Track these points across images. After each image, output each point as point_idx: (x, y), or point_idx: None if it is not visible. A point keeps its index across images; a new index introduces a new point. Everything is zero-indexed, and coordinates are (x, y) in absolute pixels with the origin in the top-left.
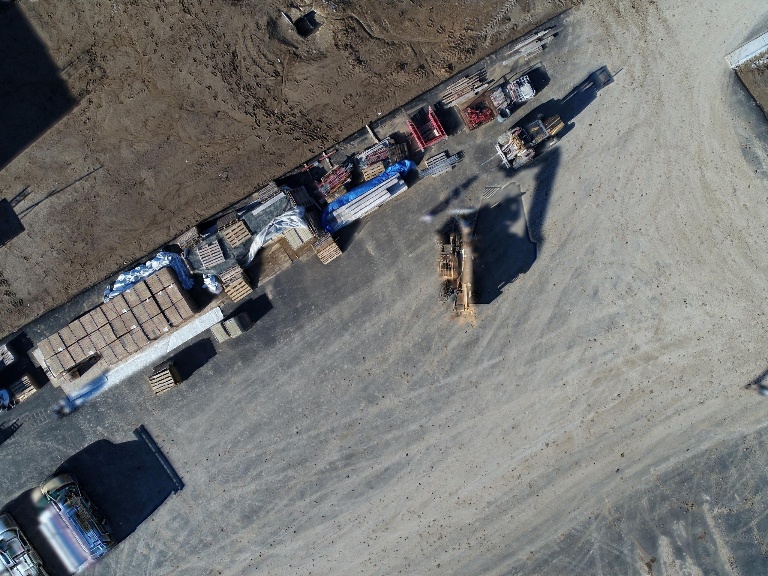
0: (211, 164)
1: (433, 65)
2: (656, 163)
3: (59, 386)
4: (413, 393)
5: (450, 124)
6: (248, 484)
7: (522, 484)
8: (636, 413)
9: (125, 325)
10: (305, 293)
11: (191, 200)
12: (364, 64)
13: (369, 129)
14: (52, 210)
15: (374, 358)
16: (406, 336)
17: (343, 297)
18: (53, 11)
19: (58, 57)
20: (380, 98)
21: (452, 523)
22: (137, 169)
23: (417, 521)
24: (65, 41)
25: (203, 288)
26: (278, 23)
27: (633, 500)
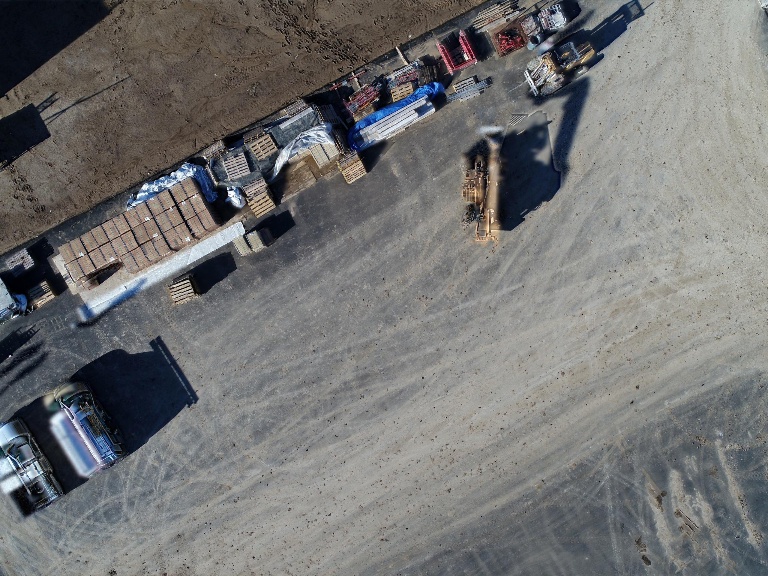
0: (240, 79)
1: None
2: (683, 98)
3: (77, 294)
4: (431, 316)
5: (480, 50)
6: (262, 400)
7: (536, 412)
8: (653, 346)
9: (147, 233)
10: (328, 212)
11: (218, 114)
12: None
13: (399, 51)
14: (79, 117)
15: (394, 280)
16: (427, 259)
17: (366, 217)
18: None
19: None
20: (411, 21)
21: (465, 448)
22: (165, 80)
23: (430, 445)
24: None
25: (226, 202)
26: None
27: (646, 433)
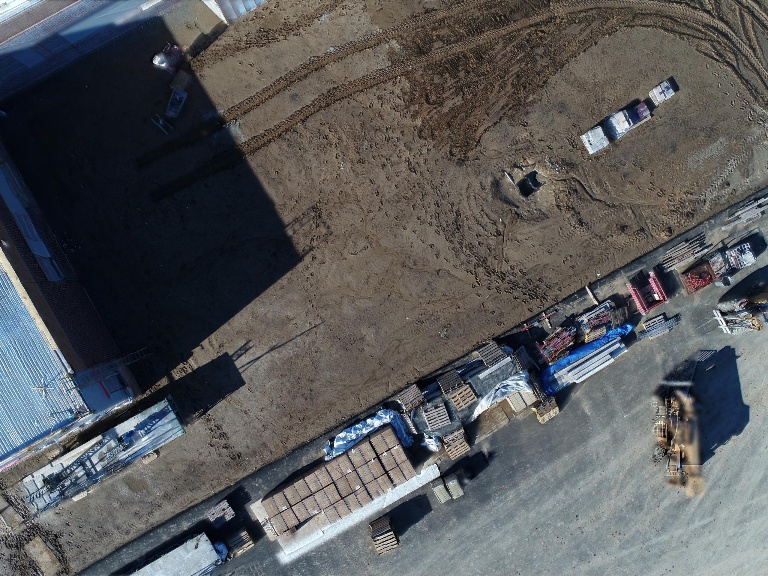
0: (431, 321)
1: (652, 228)
2: None
3: (275, 540)
4: (625, 552)
5: (668, 287)
6: None
7: None
8: None
9: (350, 486)
10: (521, 451)
11: (410, 357)
12: (585, 226)
13: (589, 291)
14: (273, 364)
15: (587, 517)
16: (619, 495)
17: (558, 456)
18: (280, 167)
19: (283, 213)
20: (599, 259)
21: None
22: (358, 325)
23: None
24: (291, 197)
25: (421, 445)
26: (500, 182)
27: None
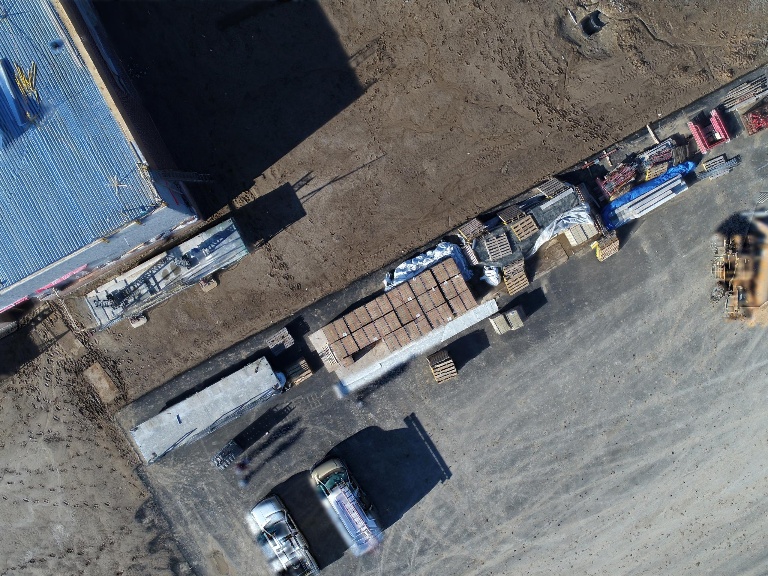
0: (492, 157)
1: (714, 69)
2: None
3: (333, 371)
4: (681, 392)
5: (729, 128)
6: (515, 476)
7: None
8: None
9: (411, 313)
10: (579, 289)
11: (471, 192)
12: (647, 65)
13: (650, 129)
14: (334, 196)
15: (644, 356)
16: (676, 335)
17: (616, 294)
18: None
19: (347, 44)
20: (660, 99)
21: (714, 522)
22: (419, 159)
23: (680, 519)
24: (355, 29)
25: (481, 280)
26: (563, 21)
27: None
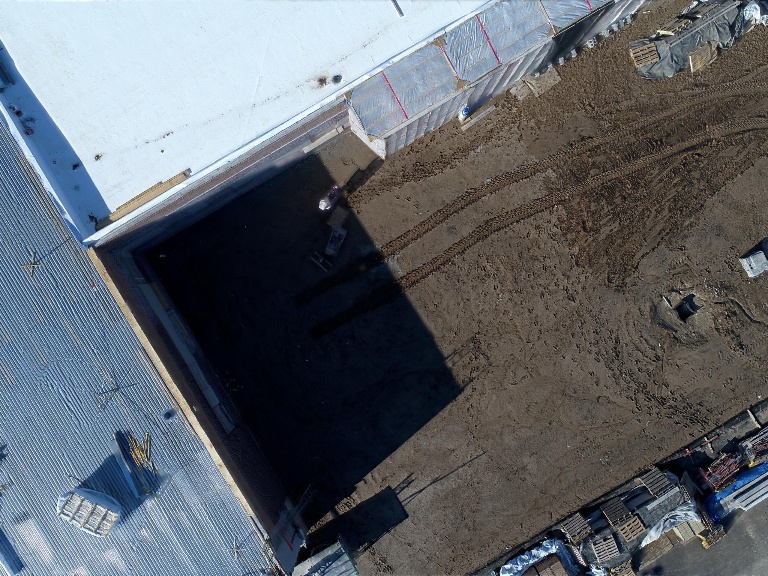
0: (592, 448)
1: None
2: None
3: None
4: None
5: None
6: None
7: None
8: None
9: None
10: None
11: (572, 484)
12: (745, 348)
13: (751, 414)
14: (435, 496)
15: None
16: None
17: None
18: (439, 300)
19: (442, 345)
20: (760, 381)
21: None
22: (519, 455)
23: None
24: (450, 329)
25: (586, 574)
26: (658, 306)
27: None
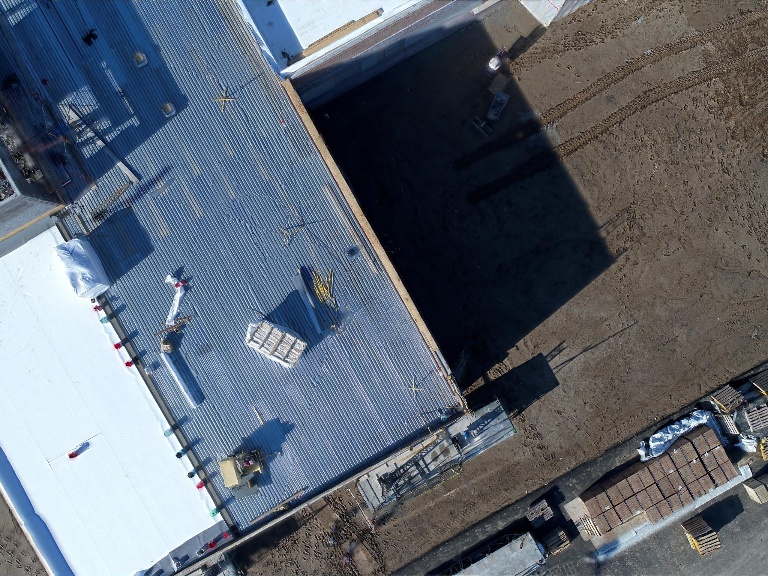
0: (742, 322)
1: None
2: None
3: (589, 540)
4: None
5: None
6: None
7: None
8: None
9: (673, 486)
10: None
11: (721, 357)
12: None
13: None
14: (586, 365)
15: None
16: None
17: None
18: (595, 169)
19: (598, 214)
20: None
21: None
22: (670, 326)
23: None
24: (605, 198)
25: (735, 446)
26: None
27: None
